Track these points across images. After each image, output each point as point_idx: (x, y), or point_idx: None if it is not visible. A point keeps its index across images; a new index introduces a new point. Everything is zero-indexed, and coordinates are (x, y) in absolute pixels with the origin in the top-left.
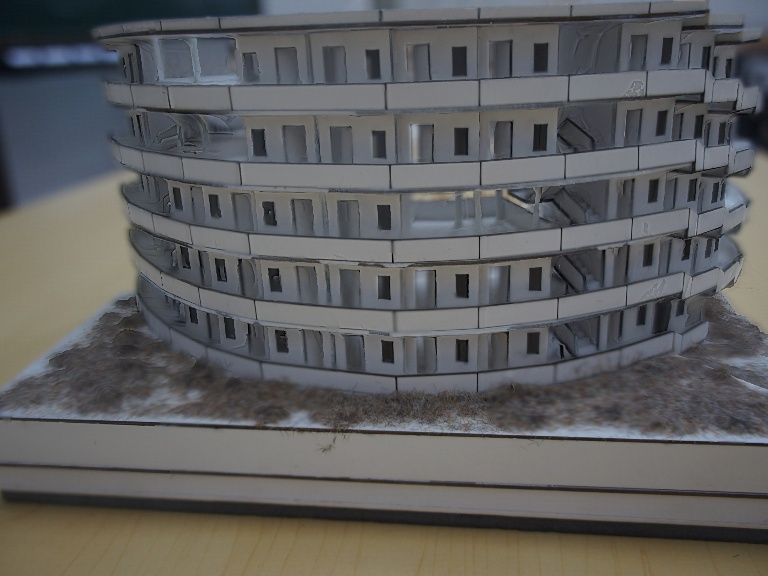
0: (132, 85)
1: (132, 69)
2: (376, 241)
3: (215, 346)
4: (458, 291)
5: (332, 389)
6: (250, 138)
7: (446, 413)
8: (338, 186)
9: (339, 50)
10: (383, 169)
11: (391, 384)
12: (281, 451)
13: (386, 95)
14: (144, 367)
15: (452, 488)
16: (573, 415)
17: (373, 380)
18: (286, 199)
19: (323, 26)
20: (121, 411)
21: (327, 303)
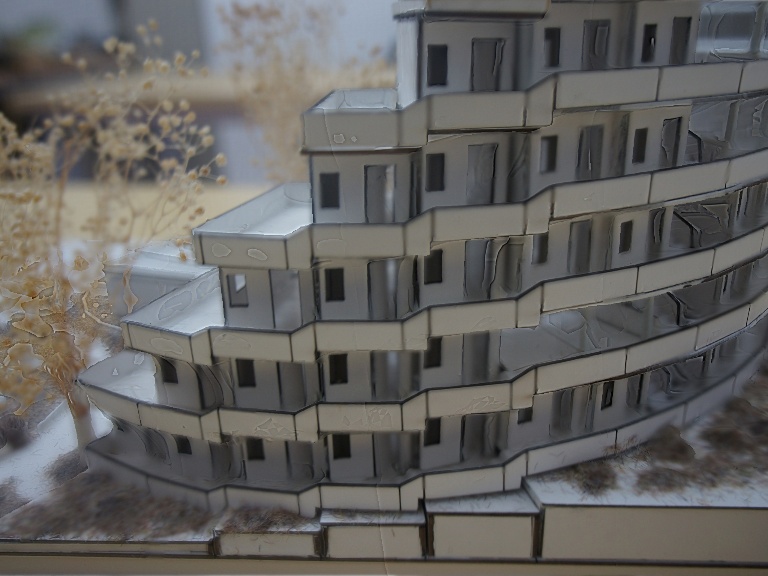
0: None
1: None
2: None
3: (760, 342)
4: None
5: None
6: None
7: None
8: None
9: None
10: None
11: None
12: None
13: None
14: None
15: None
16: None
17: None
18: None
19: None
20: None
21: None
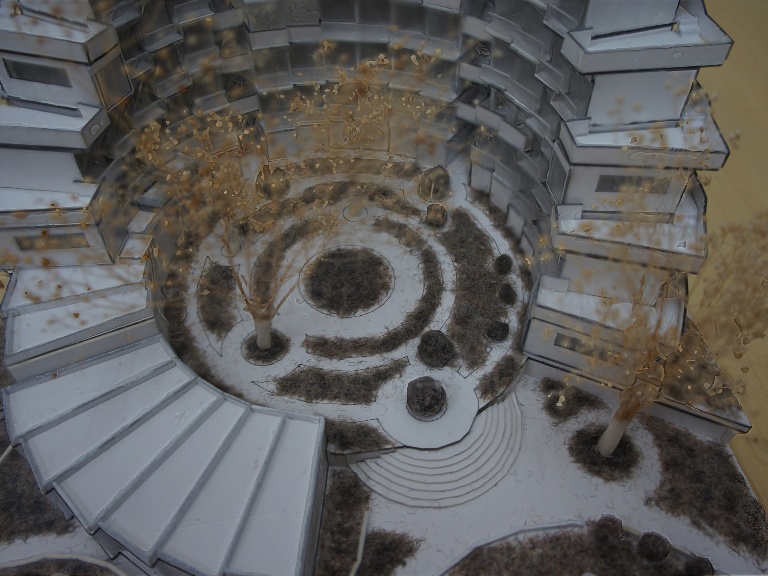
0: None
1: None
2: None
3: None
4: None
5: None
6: None
7: None
8: None
9: None
10: None
11: None
12: None
13: None
14: None
15: None
16: None
17: None
18: None
19: None
20: None
21: None
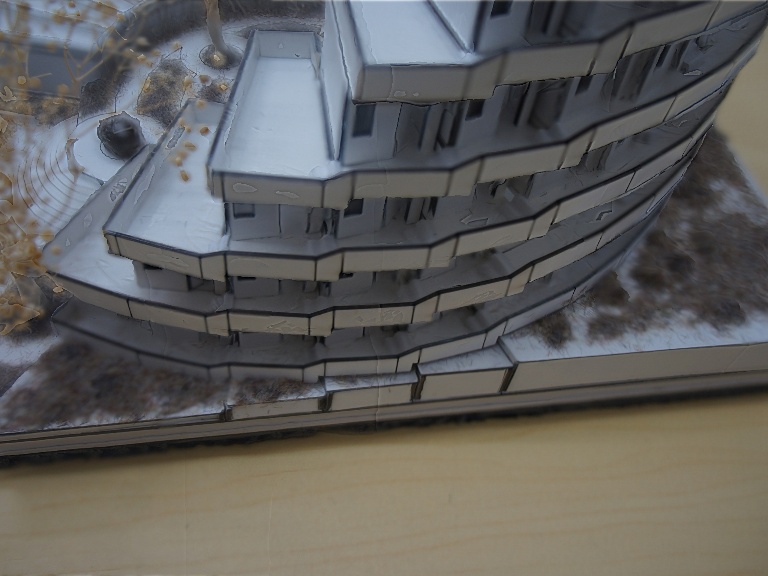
0: None
1: None
2: None
3: None
4: None
5: None
6: None
7: None
8: None
9: None
10: None
11: None
12: None
13: None
14: None
15: None
16: None
17: None
18: None
19: None
20: None
21: None
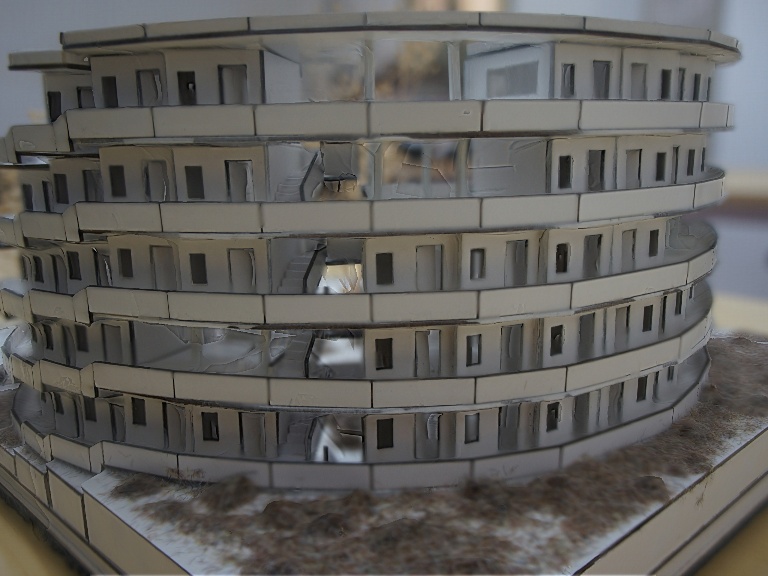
0: (380, 102)
1: (222, 89)
2: (680, 264)
3: None
4: (675, 309)
5: (627, 446)
6: (556, 167)
7: (721, 424)
8: (659, 210)
9: (638, 68)
10: (692, 188)
11: (670, 417)
12: (674, 525)
13: (701, 113)
14: (423, 523)
15: (752, 491)
16: (767, 391)
17: (659, 419)
18: (583, 237)
19: (673, 39)
20: (537, 572)
21: (603, 352)
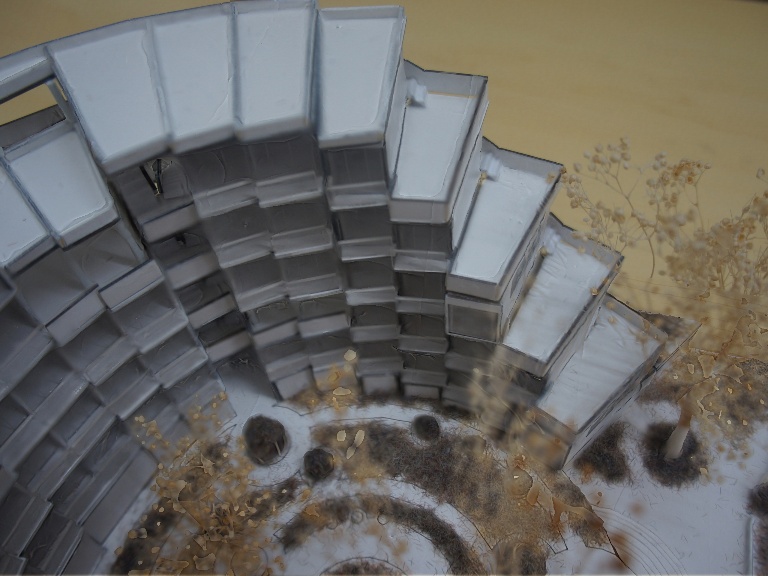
0: None
1: None
2: None
3: None
4: None
5: None
6: None
7: None
8: None
9: None
10: None
11: None
12: None
13: None
14: None
15: None
16: None
17: None
18: None
19: None
20: None
21: None
